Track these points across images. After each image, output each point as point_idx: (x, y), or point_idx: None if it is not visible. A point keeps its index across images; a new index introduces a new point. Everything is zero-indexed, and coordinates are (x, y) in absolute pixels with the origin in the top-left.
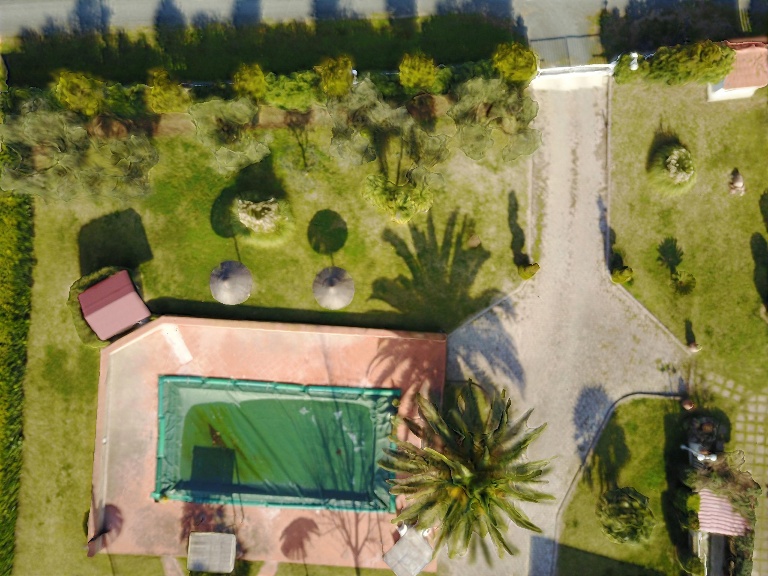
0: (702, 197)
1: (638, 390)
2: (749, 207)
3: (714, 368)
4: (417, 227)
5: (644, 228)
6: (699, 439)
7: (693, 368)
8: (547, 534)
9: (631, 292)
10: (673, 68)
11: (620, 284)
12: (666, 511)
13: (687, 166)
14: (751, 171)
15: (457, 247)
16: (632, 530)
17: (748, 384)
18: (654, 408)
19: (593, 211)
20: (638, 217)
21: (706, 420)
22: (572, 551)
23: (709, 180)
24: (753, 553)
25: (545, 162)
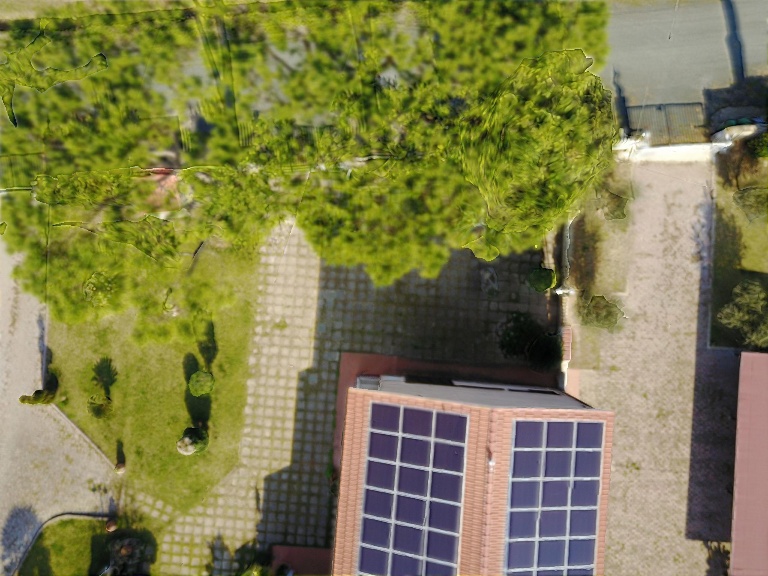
0: (136, 317)
1: (68, 510)
2: (183, 327)
3: (144, 488)
4: None
5: (80, 348)
6: (116, 562)
7: (124, 488)
8: None
9: (65, 412)
10: (75, 195)
11: (54, 404)
12: None
13: (109, 289)
14: (186, 291)
15: None
16: None
17: (176, 505)
18: (82, 529)
19: (33, 330)
20: (75, 336)
21: (129, 542)
22: None
23: (144, 300)
24: None
25: None
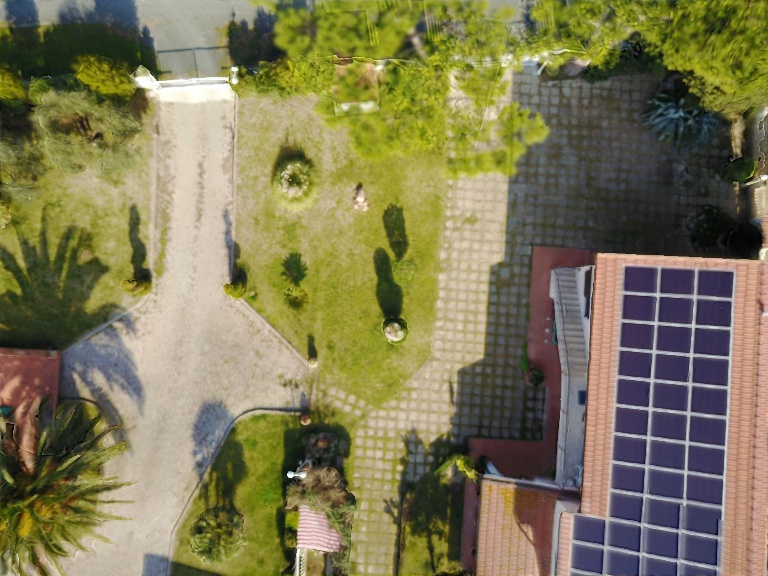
0: (326, 212)
1: (260, 406)
2: (373, 222)
3: (336, 383)
4: (28, 241)
5: (269, 243)
6: (313, 455)
7: (315, 383)
8: (161, 552)
9: (254, 307)
10: (276, 83)
11: (243, 299)
12: (281, 527)
13: (303, 181)
14: (376, 186)
15: (71, 262)
16: (209, 549)
17: (369, 399)
18: (275, 424)
19: (219, 225)
20: (263, 232)
21: (323, 436)
22: (185, 569)
23: (334, 195)
24: (369, 568)
25: (171, 175)
